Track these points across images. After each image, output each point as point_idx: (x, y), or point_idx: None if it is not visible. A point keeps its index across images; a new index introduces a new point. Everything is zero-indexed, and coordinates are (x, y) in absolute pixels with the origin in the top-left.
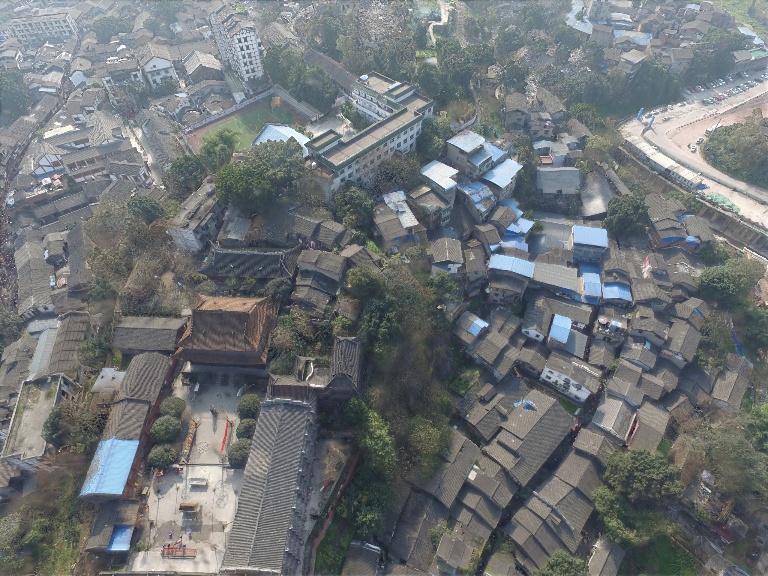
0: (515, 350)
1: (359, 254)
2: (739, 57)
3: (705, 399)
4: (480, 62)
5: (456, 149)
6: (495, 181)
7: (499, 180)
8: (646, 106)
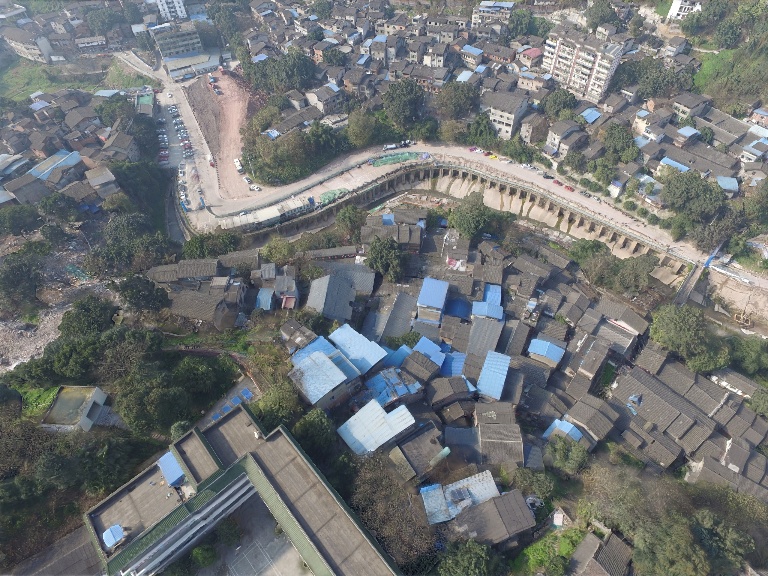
0: (585, 398)
1: (606, 568)
2: (147, 112)
3: (568, 274)
4: (106, 323)
5: (328, 394)
6: (375, 360)
7: (373, 355)
8: (158, 200)
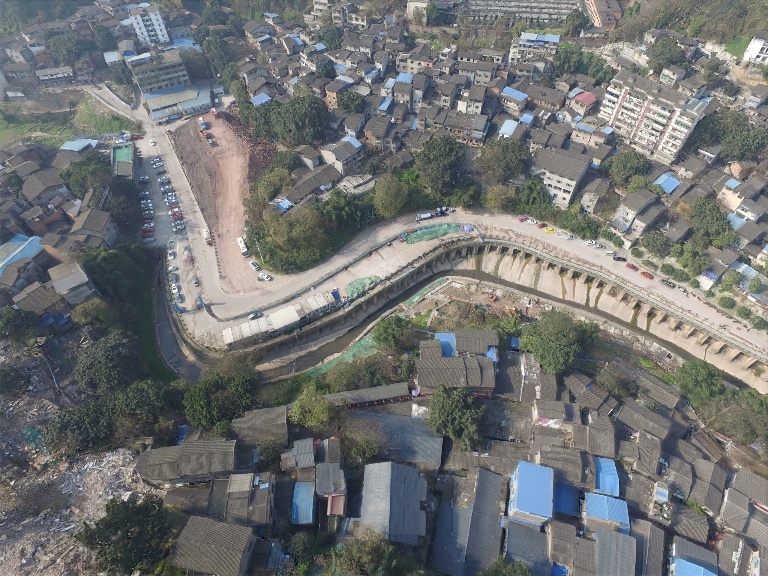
0: None
1: None
2: (126, 173)
3: (681, 418)
4: None
5: None
6: None
7: None
8: (143, 290)
